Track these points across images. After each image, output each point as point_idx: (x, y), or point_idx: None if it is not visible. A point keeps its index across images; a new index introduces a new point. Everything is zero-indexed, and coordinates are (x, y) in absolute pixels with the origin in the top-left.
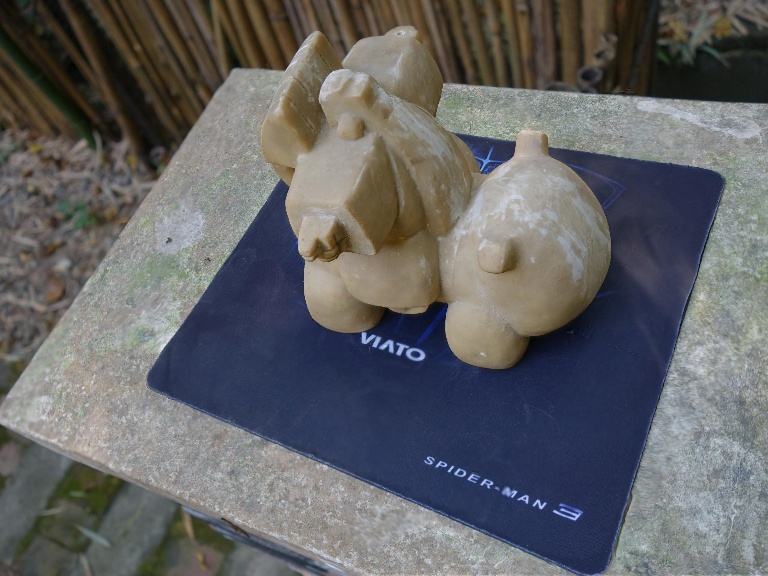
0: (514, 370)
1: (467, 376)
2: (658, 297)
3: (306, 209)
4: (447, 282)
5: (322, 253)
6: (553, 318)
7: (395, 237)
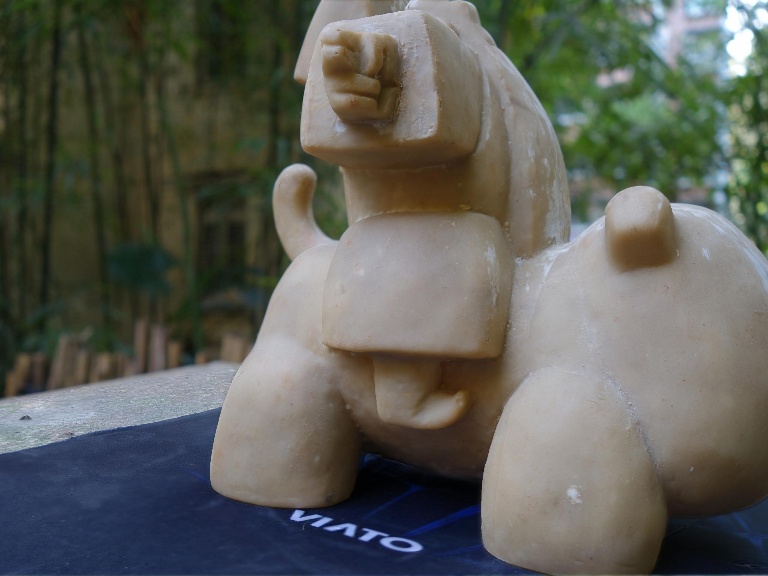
0: None
1: None
2: None
3: None
4: (520, 326)
5: (354, 72)
6: (741, 412)
7: (453, 206)
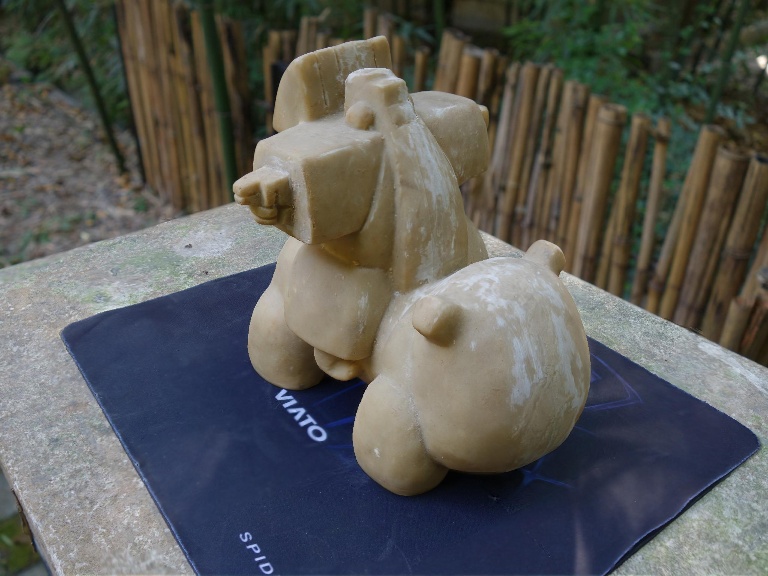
0: (405, 500)
1: (352, 479)
2: (616, 515)
3: (269, 158)
4: (380, 345)
5: (257, 206)
6: (469, 440)
7: (350, 259)
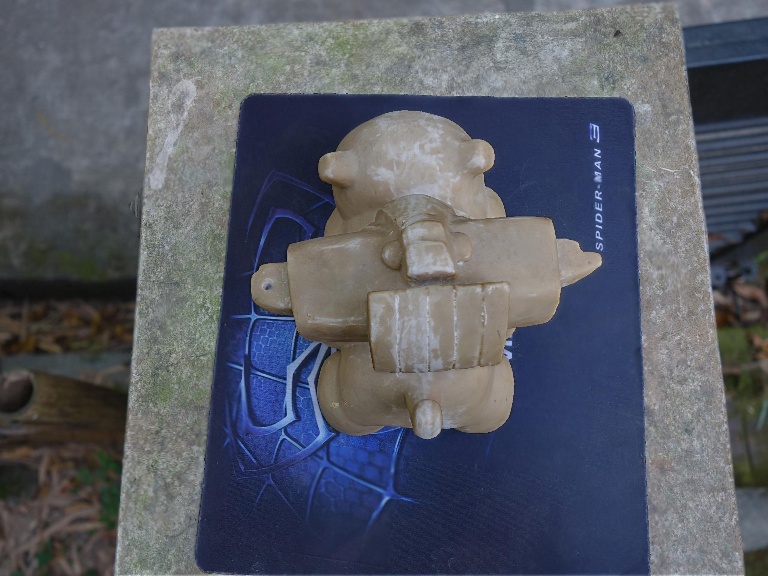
0: None
1: None
2: None
3: None
4: None
5: None
6: None
7: None
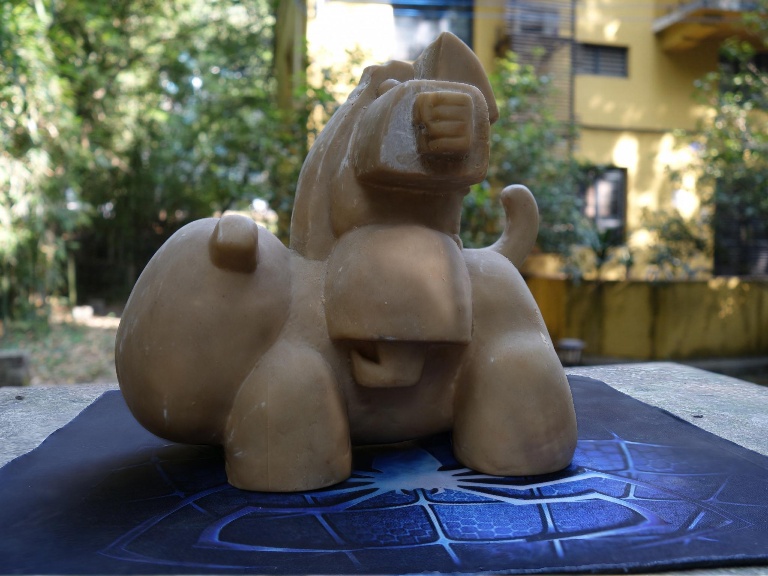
0: None
1: None
2: (44, 474)
3: None
4: None
5: None
6: None
7: None
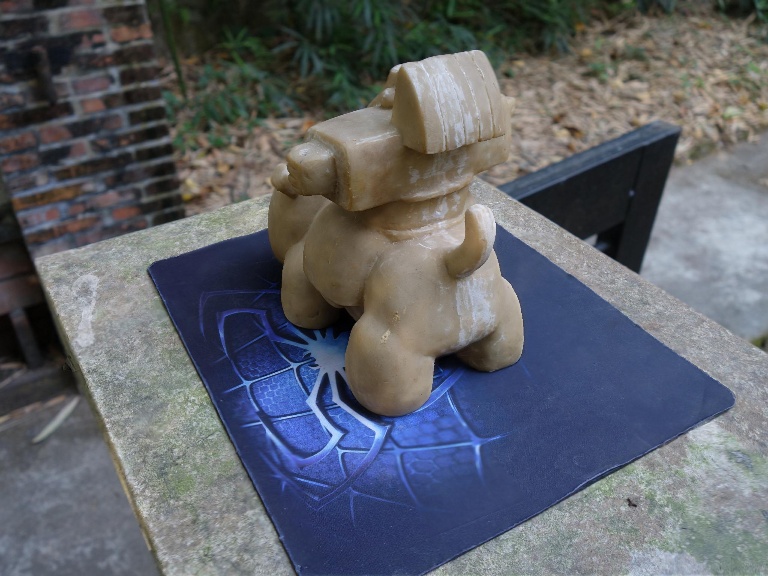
0: None
1: None
2: None
3: None
4: None
5: None
6: None
7: None
